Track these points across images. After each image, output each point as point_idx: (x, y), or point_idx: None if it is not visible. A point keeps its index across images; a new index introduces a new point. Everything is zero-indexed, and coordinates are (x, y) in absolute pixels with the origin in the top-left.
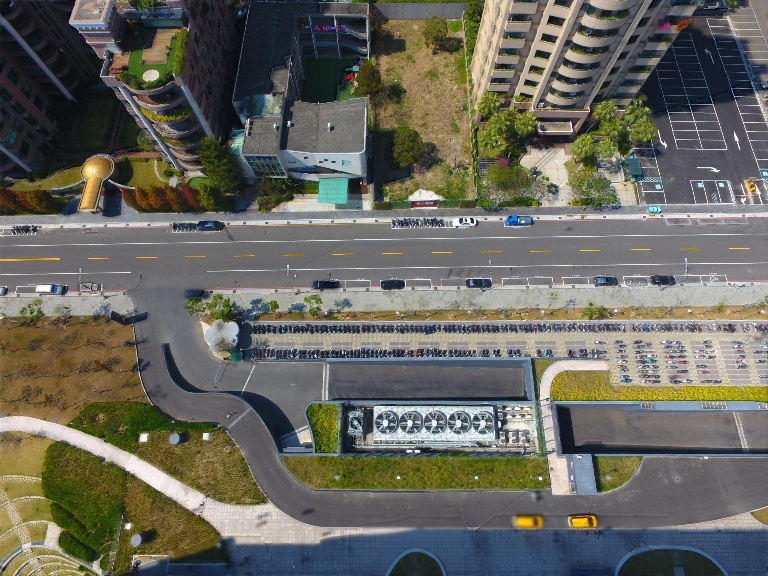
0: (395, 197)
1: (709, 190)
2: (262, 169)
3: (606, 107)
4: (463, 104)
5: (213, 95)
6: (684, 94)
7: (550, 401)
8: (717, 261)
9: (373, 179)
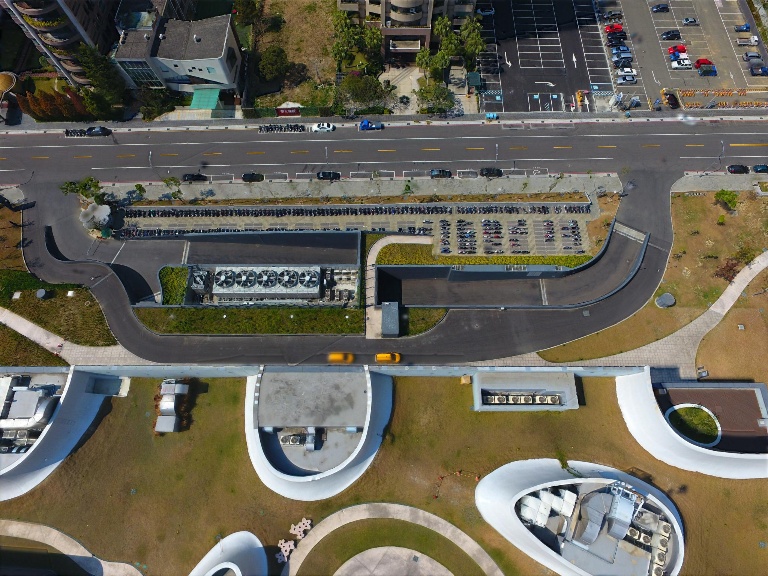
0: None
1: (543, 101)
2: (140, 78)
3: (441, 22)
4: (335, 32)
5: (95, 12)
6: (533, 23)
7: None
8: (541, 157)
9: (244, 91)
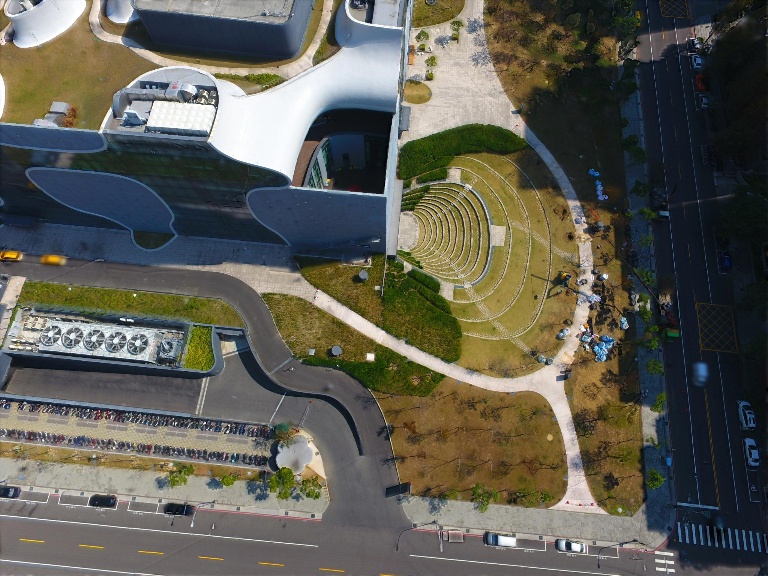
0: None
1: None
2: None
3: None
4: None
5: None
6: None
7: None
8: None
9: None
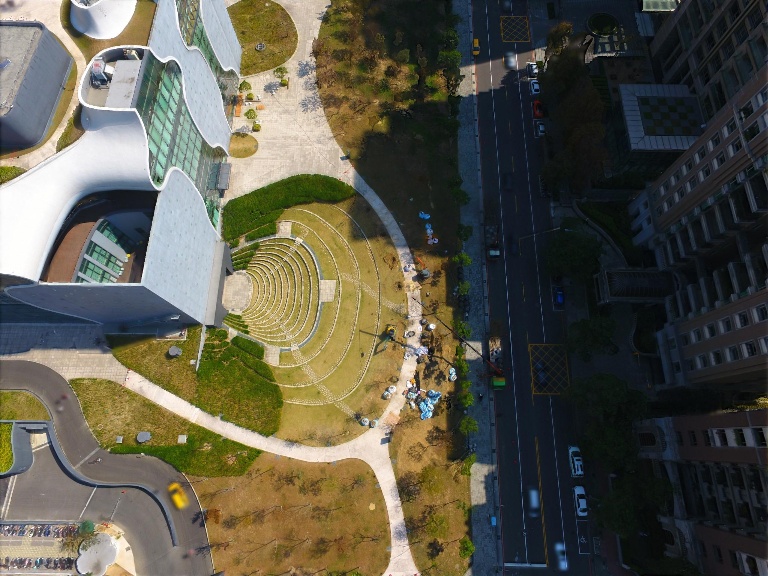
0: None
1: None
2: None
3: None
4: None
5: None
6: None
7: None
8: None
9: None
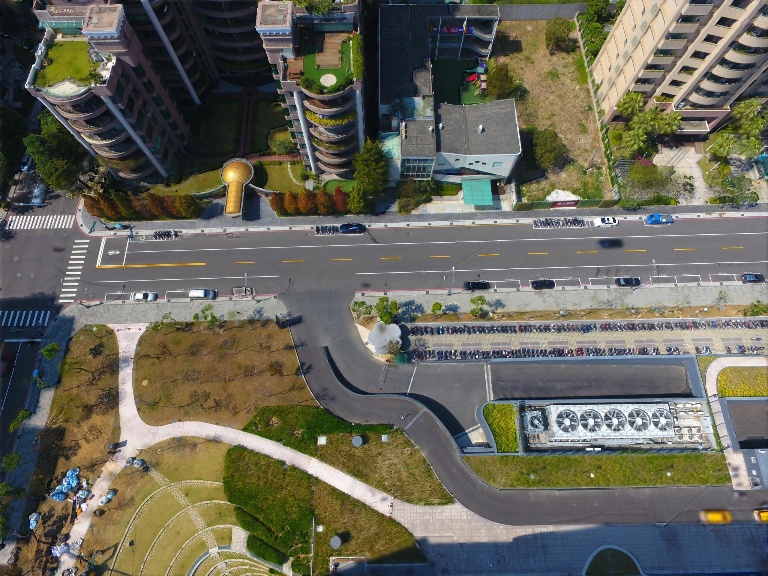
0: (533, 197)
1: None
2: (410, 171)
3: (750, 106)
4: (587, 104)
5: None
6: None
7: (718, 397)
8: None
9: (512, 180)
